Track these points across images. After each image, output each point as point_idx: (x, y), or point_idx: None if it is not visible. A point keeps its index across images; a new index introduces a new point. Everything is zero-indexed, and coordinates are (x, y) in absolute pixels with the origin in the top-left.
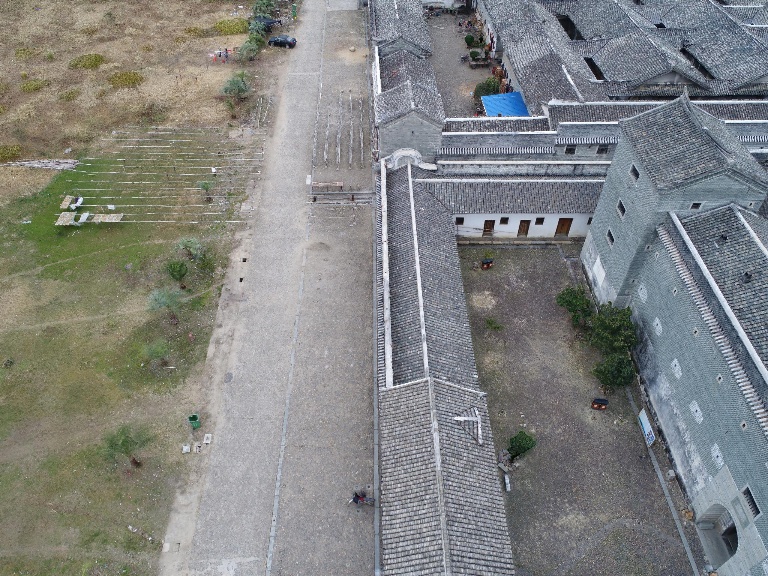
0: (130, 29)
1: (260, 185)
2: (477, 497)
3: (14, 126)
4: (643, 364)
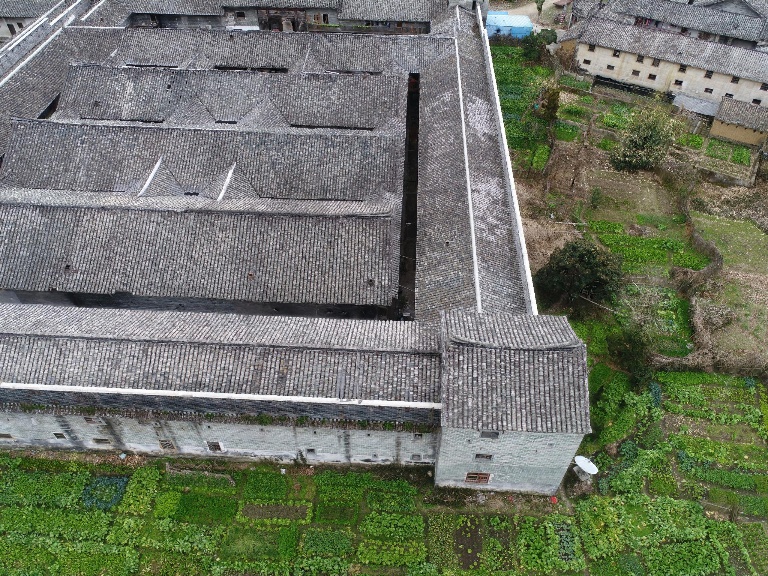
0: None
1: None
2: None
3: None
4: None
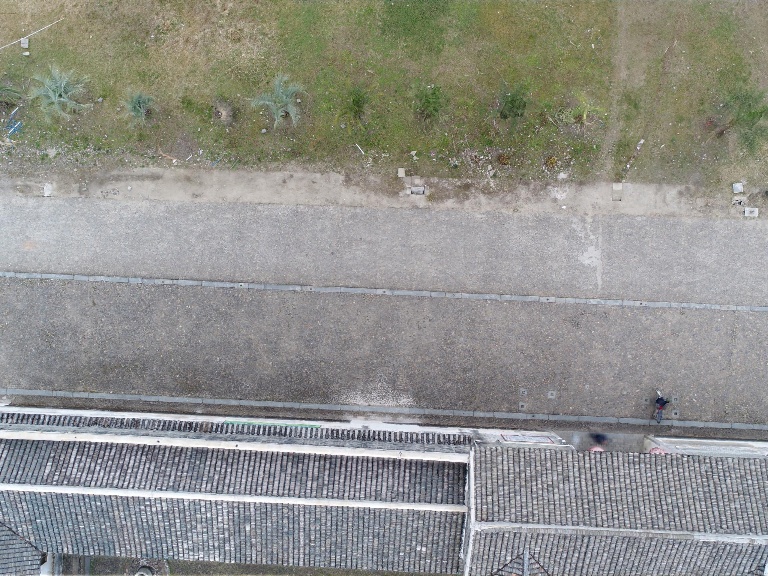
0: None
1: None
2: (656, 572)
3: None
4: None
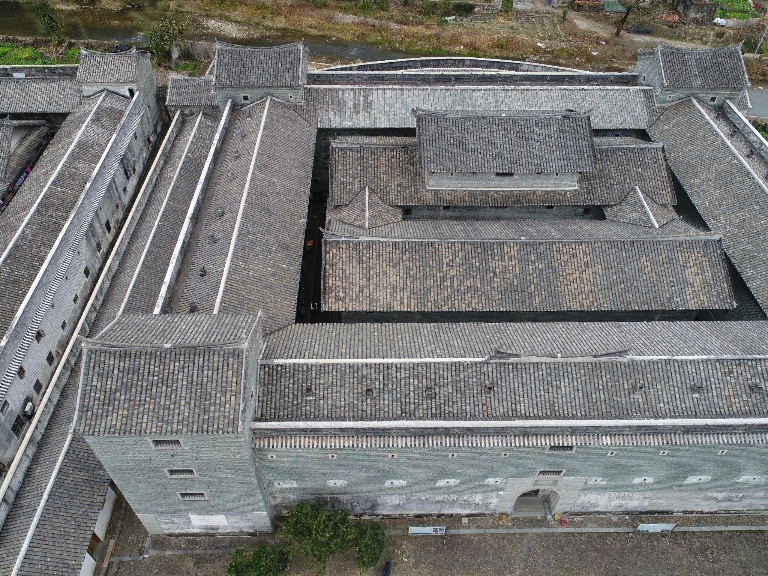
0: None
1: None
2: None
3: None
4: (348, 509)
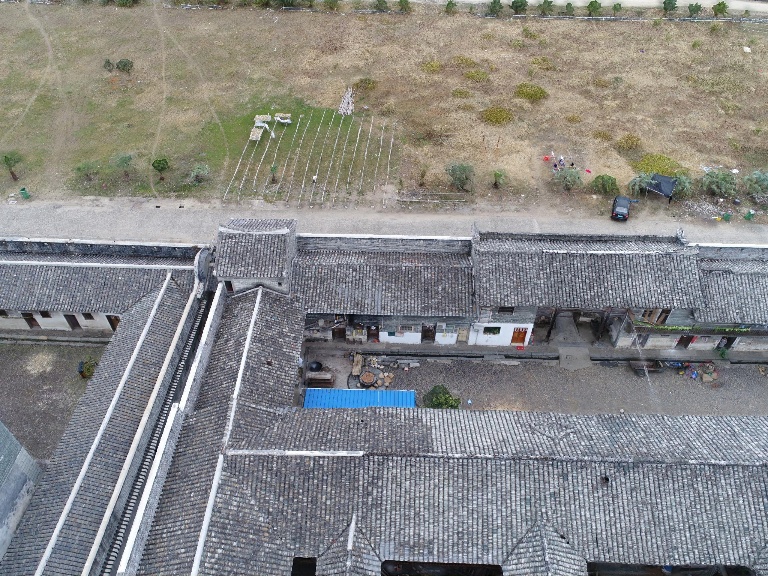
0: (613, 102)
1: (289, 208)
2: None
3: (408, 80)
4: None
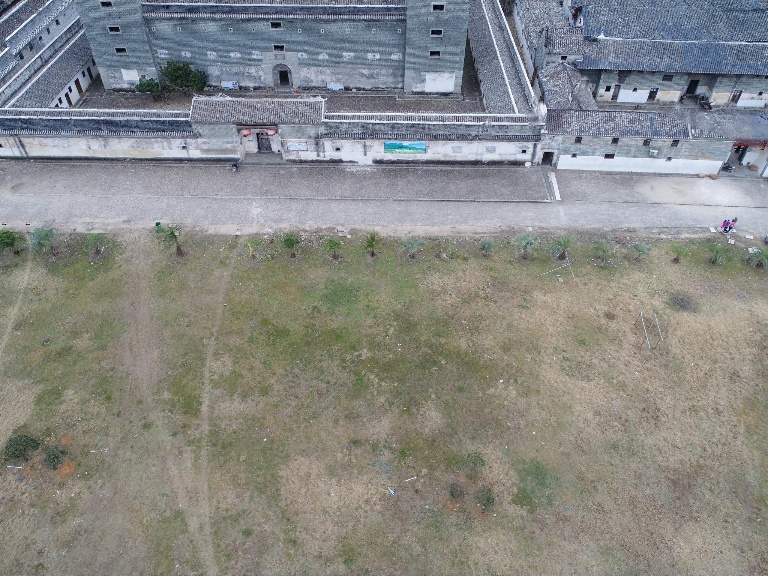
0: None
1: None
2: None
3: None
4: None
